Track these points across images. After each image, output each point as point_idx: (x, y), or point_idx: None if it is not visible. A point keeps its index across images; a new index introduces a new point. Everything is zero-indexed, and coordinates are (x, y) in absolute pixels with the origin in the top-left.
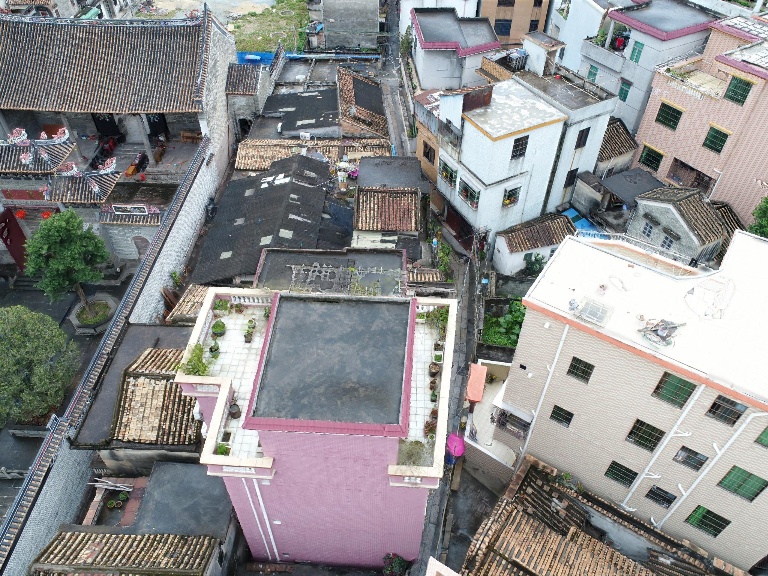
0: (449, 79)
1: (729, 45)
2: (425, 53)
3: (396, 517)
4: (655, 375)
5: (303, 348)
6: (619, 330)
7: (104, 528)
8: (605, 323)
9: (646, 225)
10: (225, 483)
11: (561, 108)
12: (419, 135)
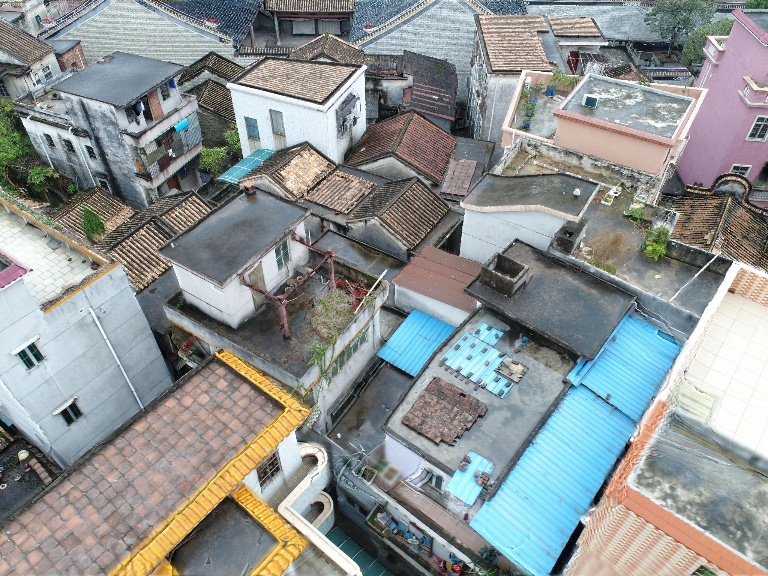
0: None
1: None
2: None
3: (723, 139)
4: None
5: None
6: None
7: None
8: None
9: None
10: (702, 68)
11: None
12: None
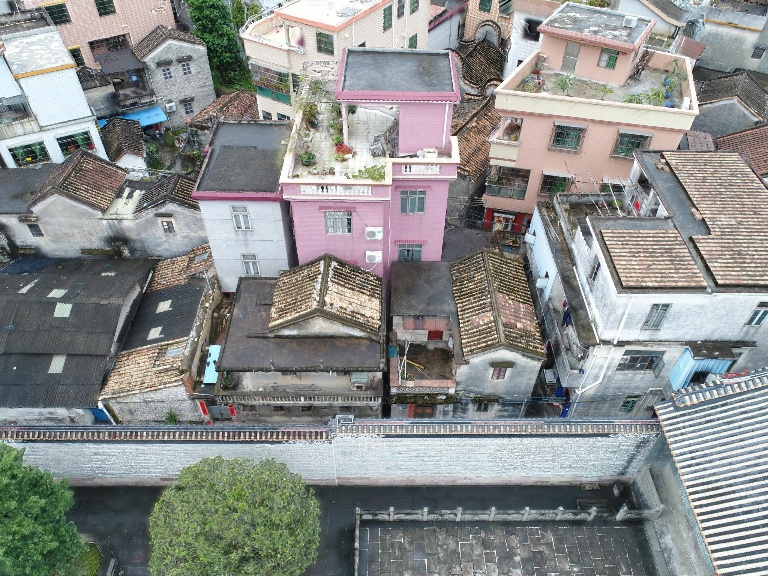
0: None
1: None
2: None
3: None
4: (382, 16)
5: (392, 84)
6: (362, 7)
7: (454, 332)
8: (359, 8)
9: (164, 71)
10: None
11: (41, 32)
12: None
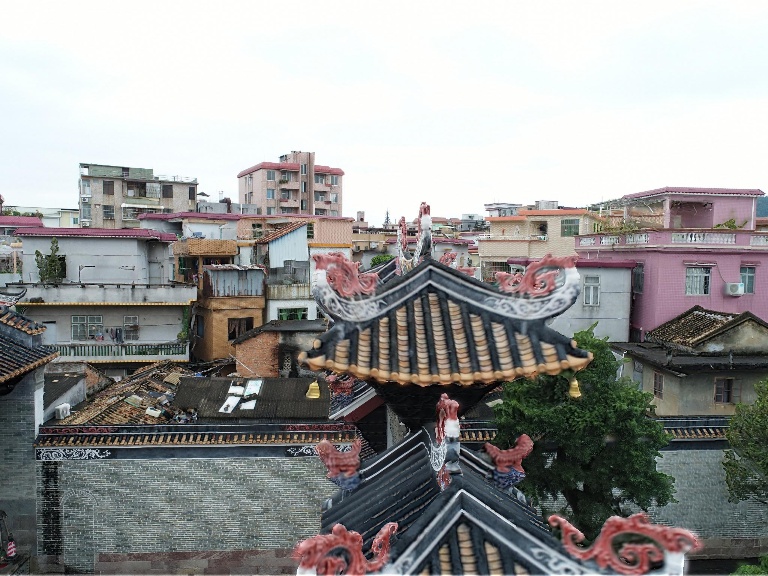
0: (145, 280)
1: (246, 225)
2: (137, 247)
3: None
4: (593, 228)
5: None
6: None
7: None
8: None
9: None
10: None
11: None
12: (217, 318)
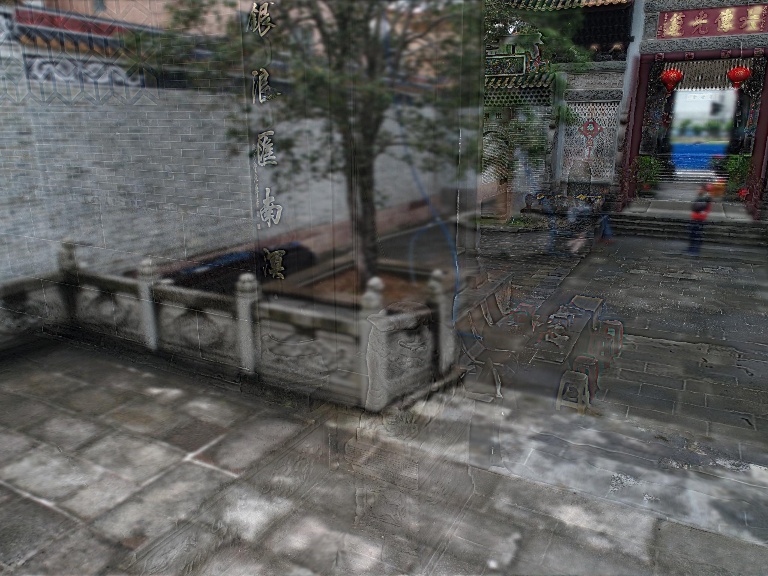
0: None
1: None
2: None
3: None
4: None
5: None
6: None
7: None
8: None
9: None
10: None
11: None
12: None
